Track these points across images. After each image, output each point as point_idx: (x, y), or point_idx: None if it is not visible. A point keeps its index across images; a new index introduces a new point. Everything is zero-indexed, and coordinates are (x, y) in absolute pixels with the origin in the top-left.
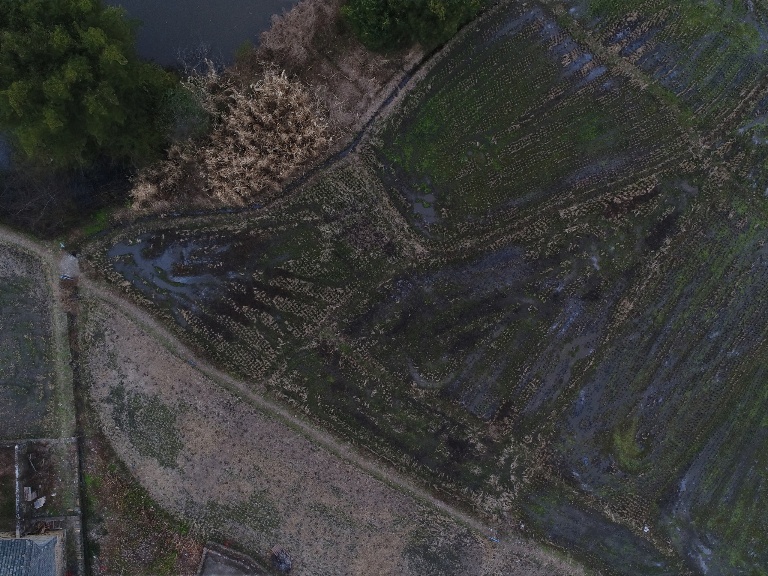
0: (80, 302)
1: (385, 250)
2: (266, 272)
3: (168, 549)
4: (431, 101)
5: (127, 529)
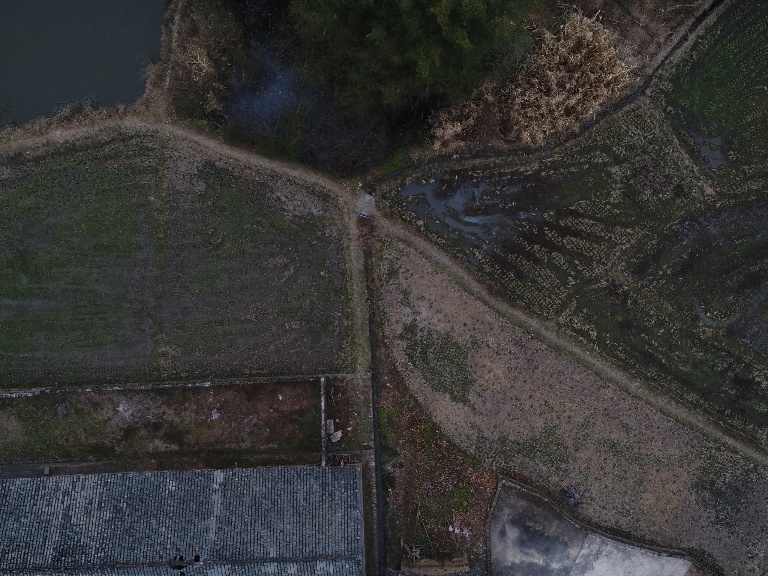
0: (376, 240)
1: (674, 191)
2: (557, 212)
3: (464, 482)
4: (719, 46)
5: (423, 462)
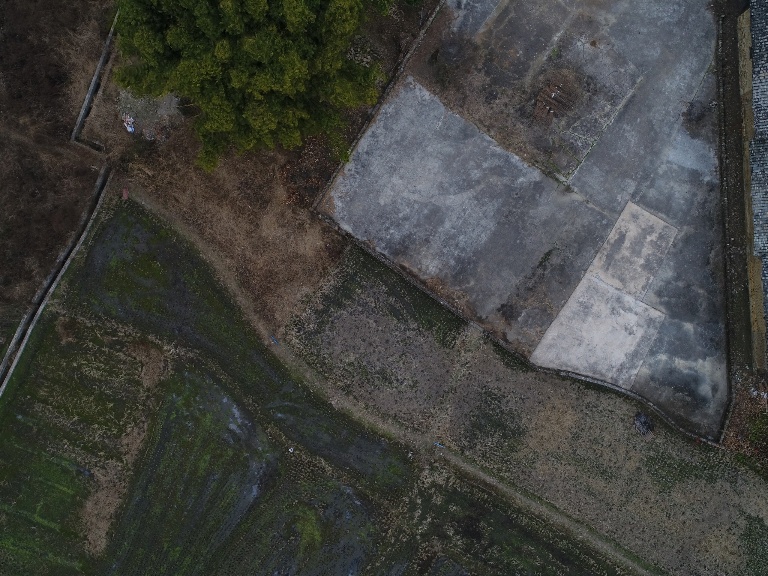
0: None
1: None
2: None
3: None
4: None
5: None
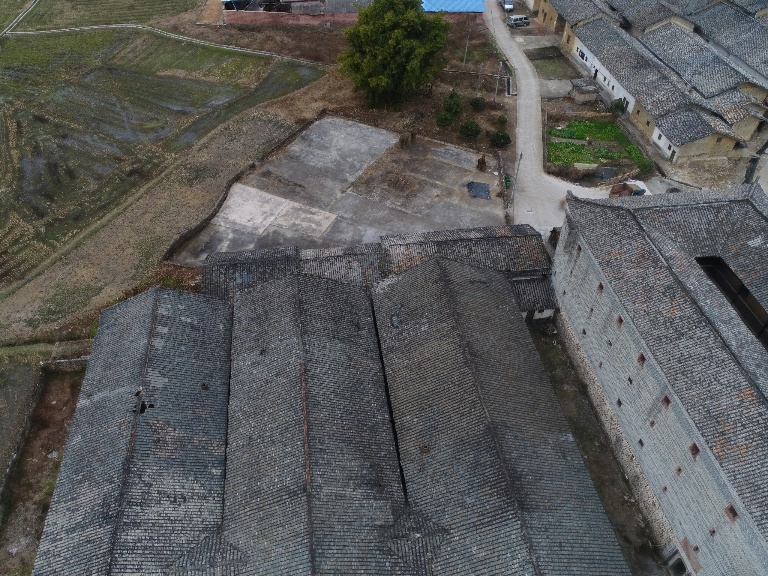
0: None
1: None
2: None
3: None
4: None
5: None
